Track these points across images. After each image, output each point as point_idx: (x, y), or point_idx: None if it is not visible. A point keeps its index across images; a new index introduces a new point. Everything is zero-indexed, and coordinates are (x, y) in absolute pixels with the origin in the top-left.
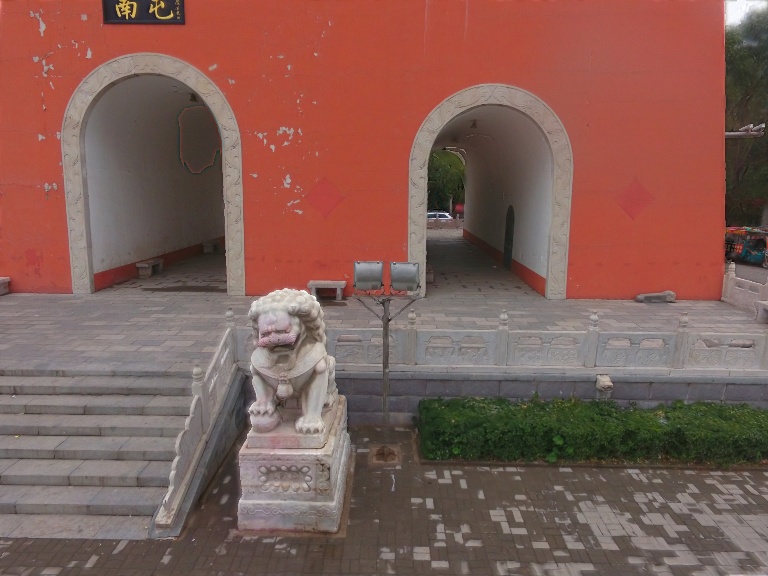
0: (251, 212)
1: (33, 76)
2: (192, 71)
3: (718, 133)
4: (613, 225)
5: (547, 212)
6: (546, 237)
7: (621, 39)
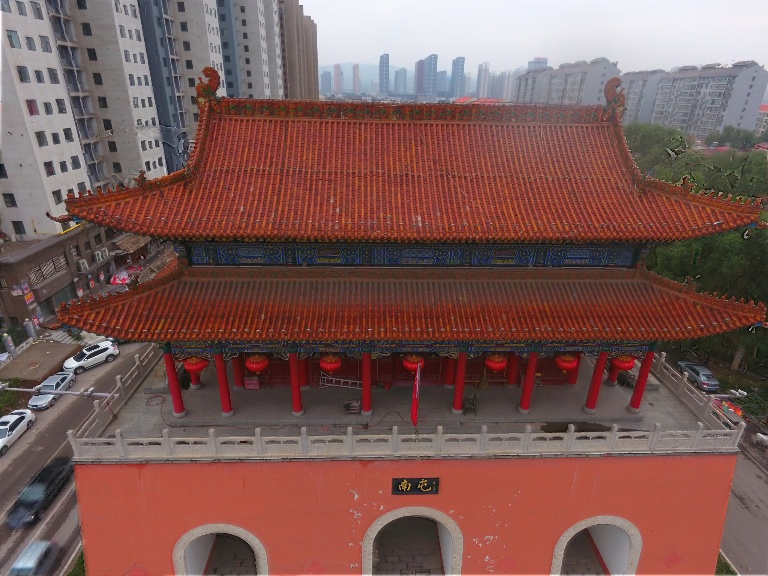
0: (465, 572)
1: (348, 518)
2: (440, 514)
3: (719, 532)
4: (658, 570)
5: (623, 560)
6: (621, 572)
7: (675, 493)
